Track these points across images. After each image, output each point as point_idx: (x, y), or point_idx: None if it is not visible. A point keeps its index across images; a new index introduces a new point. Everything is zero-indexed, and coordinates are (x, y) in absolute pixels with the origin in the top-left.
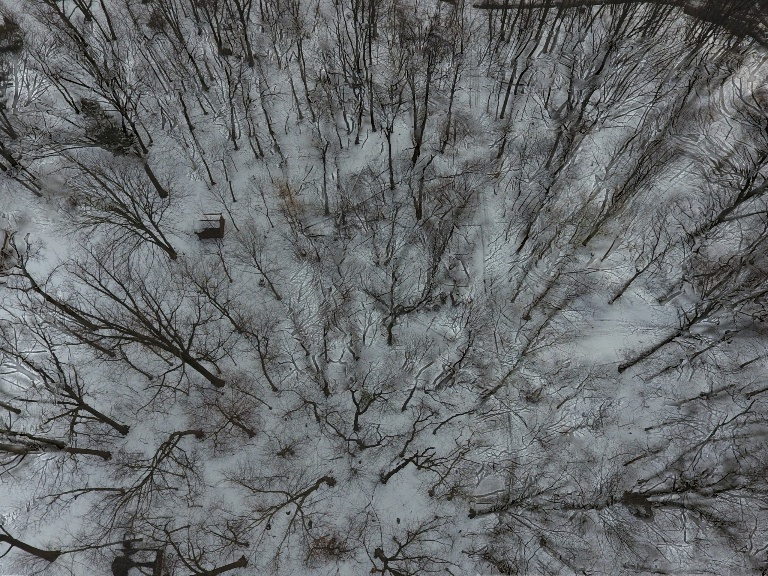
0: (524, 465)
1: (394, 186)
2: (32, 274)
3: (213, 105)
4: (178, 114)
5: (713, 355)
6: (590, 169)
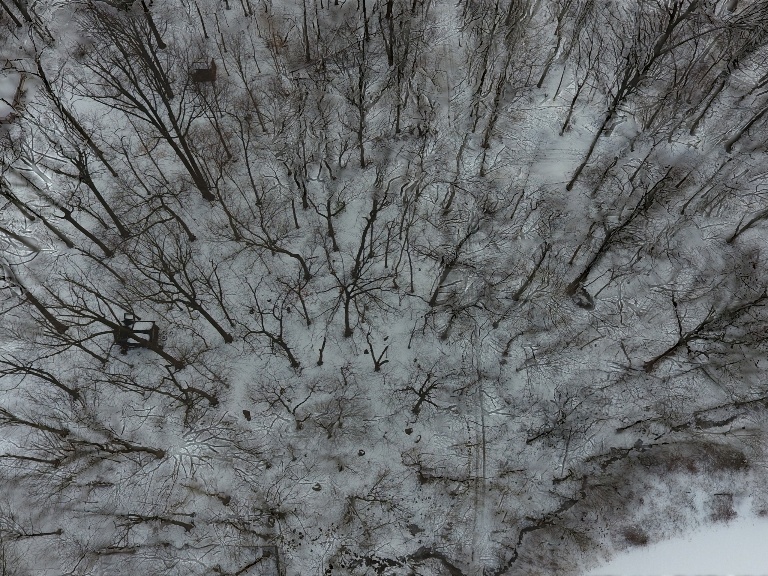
0: (480, 262)
1: (369, 37)
2: (47, 76)
3: None
4: None
5: (652, 176)
6: (544, 20)
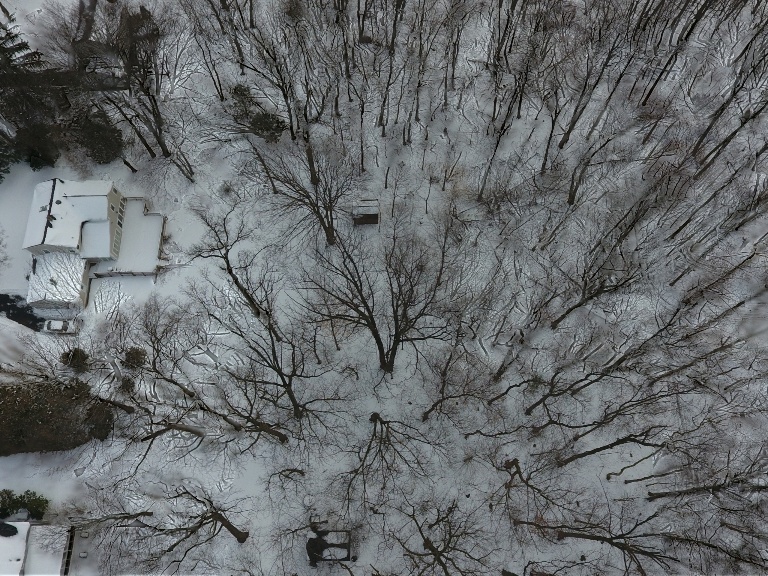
0: (698, 445)
1: (545, 172)
2: (229, 255)
3: (358, 92)
4: (328, 101)
5: None
6: (741, 154)
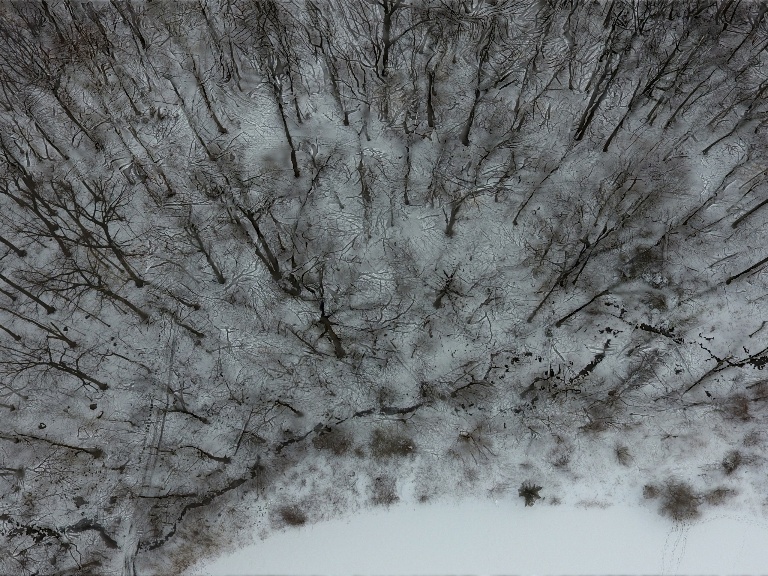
0: None
1: None
2: None
3: None
4: None
5: (381, 166)
6: None
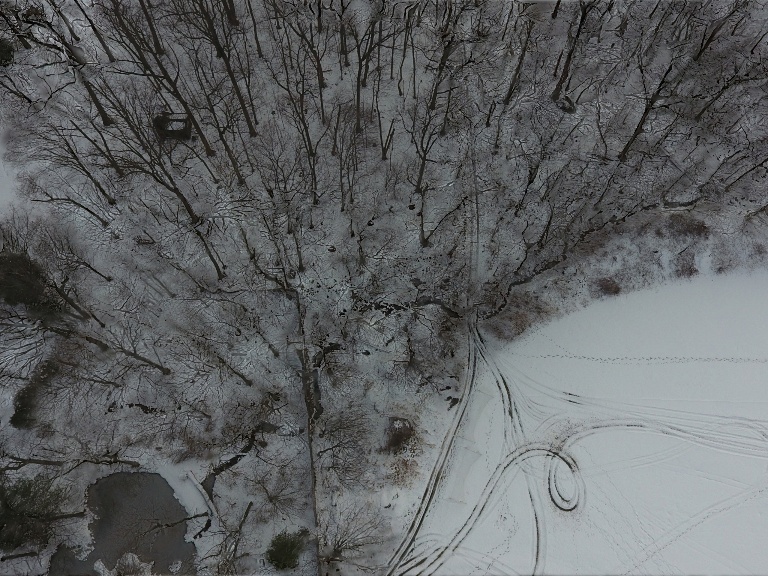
0: None
1: None
2: None
3: None
4: None
5: None
6: None
